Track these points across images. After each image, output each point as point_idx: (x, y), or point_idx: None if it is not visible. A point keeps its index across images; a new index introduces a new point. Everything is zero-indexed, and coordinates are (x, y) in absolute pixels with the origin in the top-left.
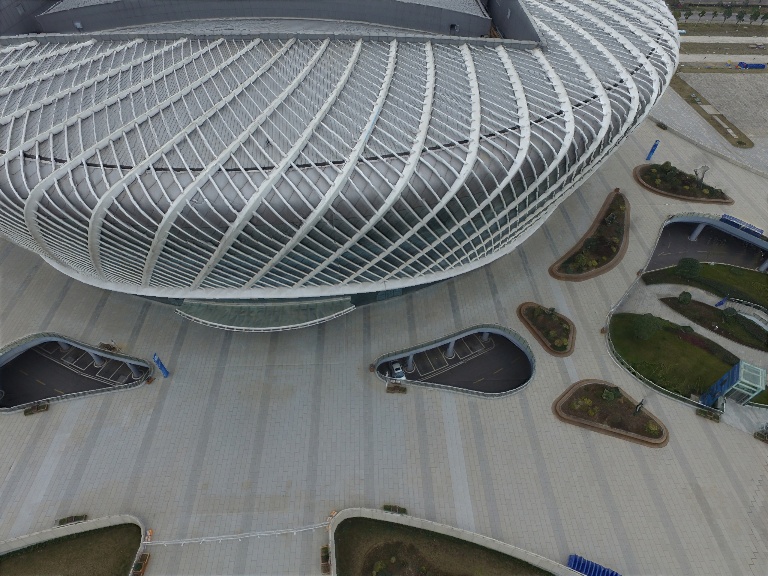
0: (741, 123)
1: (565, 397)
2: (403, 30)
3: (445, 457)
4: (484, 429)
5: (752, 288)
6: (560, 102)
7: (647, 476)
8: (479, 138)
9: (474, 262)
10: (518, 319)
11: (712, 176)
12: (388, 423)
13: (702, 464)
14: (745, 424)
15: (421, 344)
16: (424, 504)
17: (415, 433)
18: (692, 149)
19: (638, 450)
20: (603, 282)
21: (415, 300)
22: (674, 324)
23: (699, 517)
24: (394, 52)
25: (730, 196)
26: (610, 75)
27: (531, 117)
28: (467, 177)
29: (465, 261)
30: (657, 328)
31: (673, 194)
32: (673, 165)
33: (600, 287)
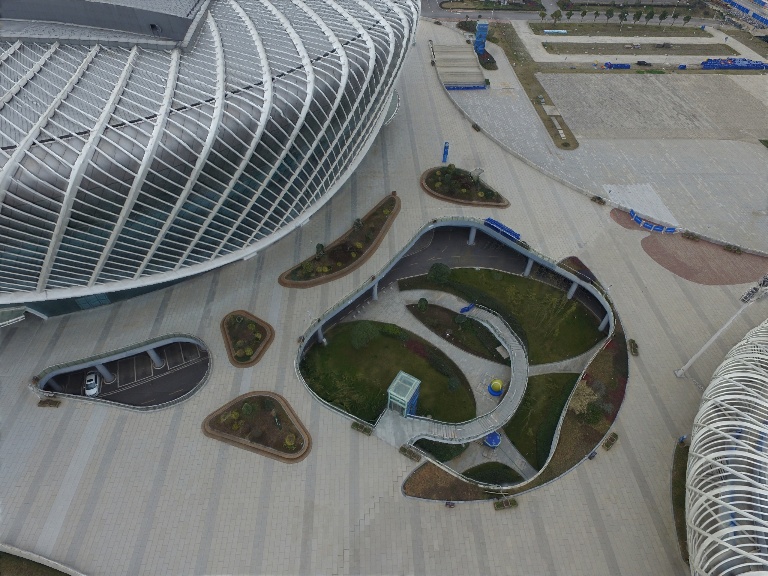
0: (576, 124)
1: (220, 410)
2: (102, 30)
3: (62, 475)
4: (119, 444)
5: (504, 294)
6: (160, 105)
7: (264, 493)
8: (32, 143)
9: (183, 269)
10: (219, 328)
11: (501, 179)
12: (22, 439)
13: (329, 480)
14: (397, 437)
15: (96, 355)
16: (12, 525)
17: (44, 449)
18: (496, 151)
19: (270, 466)
20: (329, 289)
21: (122, 309)
22: (405, 332)
23: (295, 537)
24: (3, 53)
25: (509, 199)
26: (247, 77)
27: (114, 121)
28: (7, 184)
29: (164, 268)
30: (367, 336)
31: (449, 197)
32: (467, 167)
33: (323, 294)
